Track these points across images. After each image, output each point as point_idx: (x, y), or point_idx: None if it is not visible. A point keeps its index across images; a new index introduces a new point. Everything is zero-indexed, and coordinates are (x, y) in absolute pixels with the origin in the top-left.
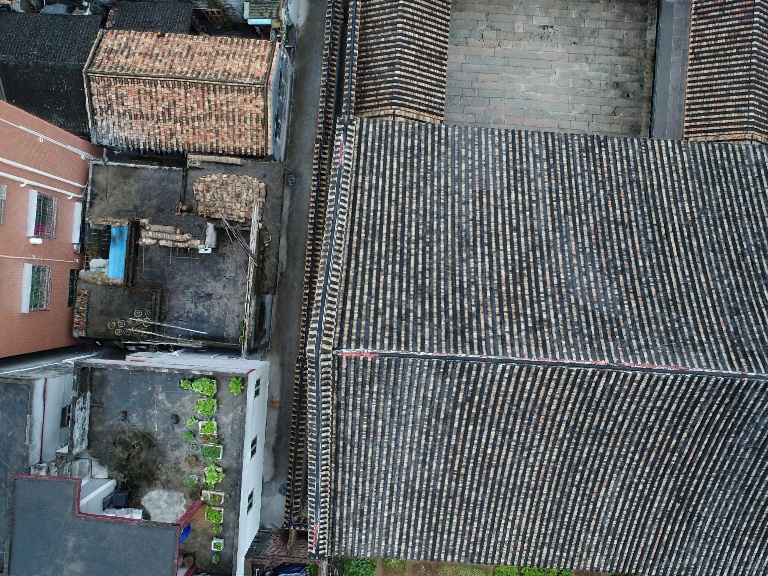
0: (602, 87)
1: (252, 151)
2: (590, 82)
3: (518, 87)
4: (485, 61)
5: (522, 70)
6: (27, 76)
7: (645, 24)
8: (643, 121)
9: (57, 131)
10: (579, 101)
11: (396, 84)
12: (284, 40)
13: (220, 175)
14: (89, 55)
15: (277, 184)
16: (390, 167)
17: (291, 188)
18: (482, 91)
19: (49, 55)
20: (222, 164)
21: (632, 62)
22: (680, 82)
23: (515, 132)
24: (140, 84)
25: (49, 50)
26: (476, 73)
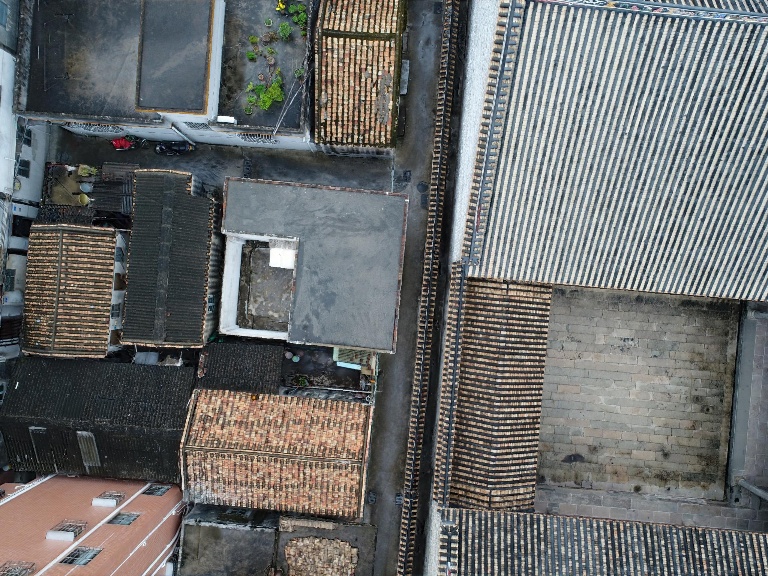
0: (682, 401)
1: (344, 513)
2: (670, 396)
3: (598, 399)
4: (565, 372)
5: (602, 382)
6: (122, 439)
7: (726, 338)
8: (722, 436)
9: (156, 517)
10: (658, 414)
11: (492, 463)
12: (374, 389)
13: (312, 539)
14: (185, 425)
15: (369, 548)
16: (491, 572)
17: (371, 506)
18: (561, 402)
19: (144, 418)
20: (314, 527)
21: (712, 376)
22: (761, 400)
23: (613, 524)
24: (236, 458)
25: (144, 412)
26: (556, 384)
